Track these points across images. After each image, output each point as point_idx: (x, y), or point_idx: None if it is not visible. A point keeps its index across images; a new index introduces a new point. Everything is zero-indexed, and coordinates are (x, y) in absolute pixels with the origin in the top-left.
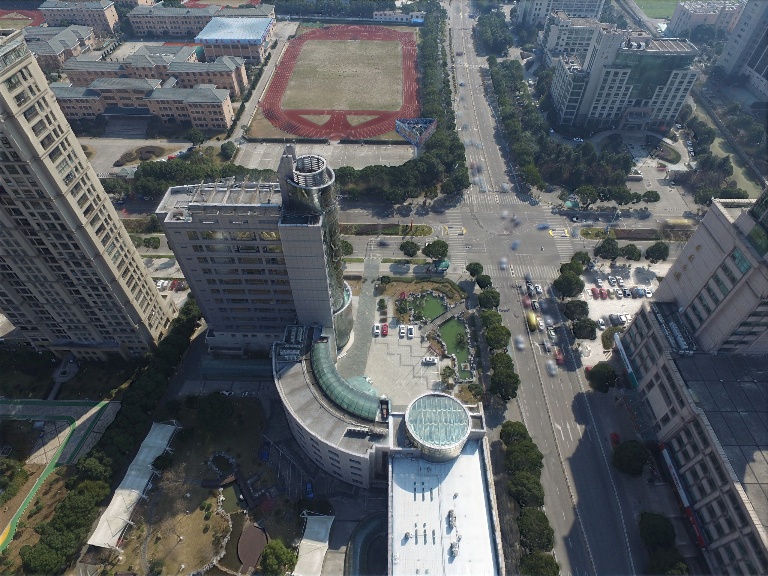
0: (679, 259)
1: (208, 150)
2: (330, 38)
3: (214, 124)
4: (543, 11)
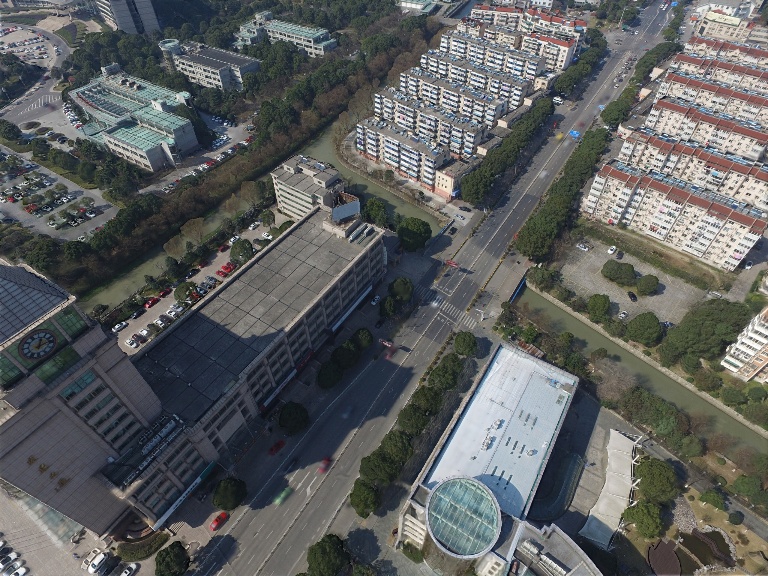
0: (37, 491)
1: None
2: None
3: None
4: None
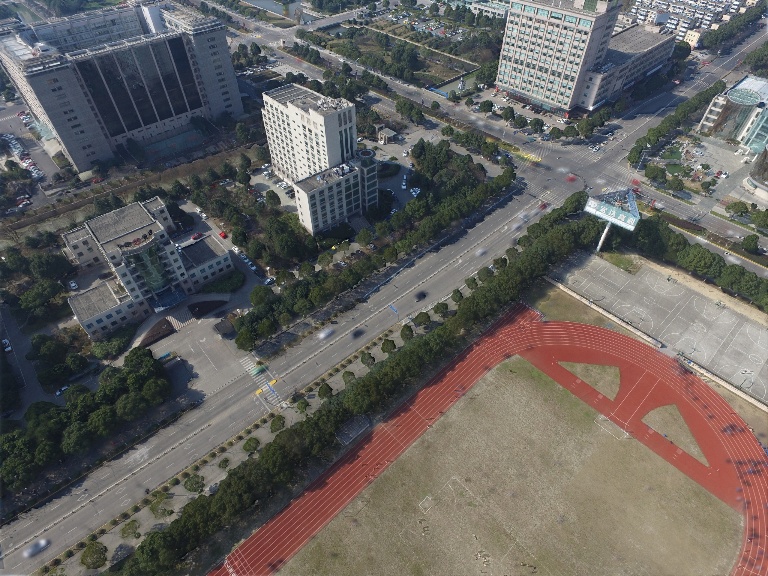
0: None
1: None
2: None
3: None
4: None
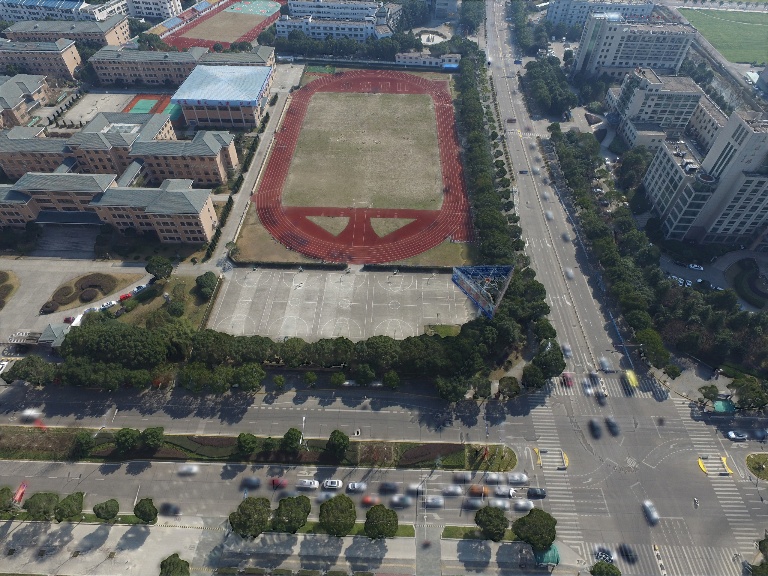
0: None
1: (176, 291)
2: (343, 89)
3: (189, 237)
4: (610, 59)
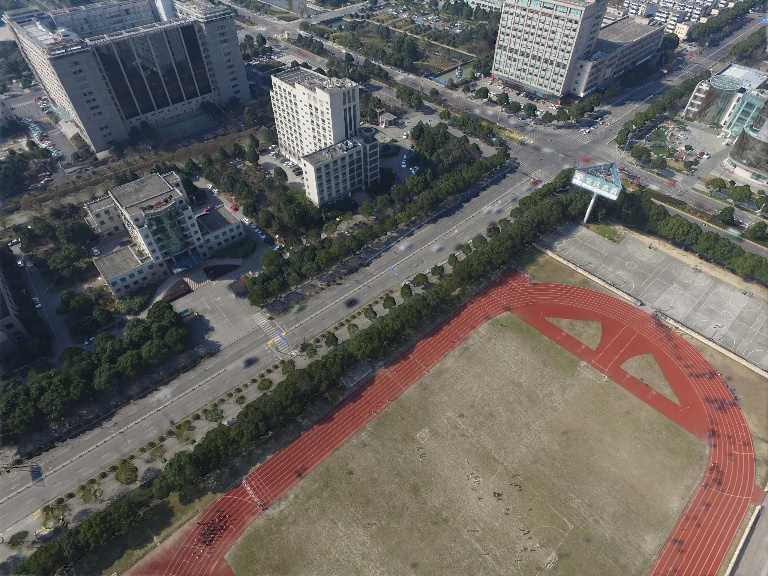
0: None
1: None
2: None
3: None
4: None
